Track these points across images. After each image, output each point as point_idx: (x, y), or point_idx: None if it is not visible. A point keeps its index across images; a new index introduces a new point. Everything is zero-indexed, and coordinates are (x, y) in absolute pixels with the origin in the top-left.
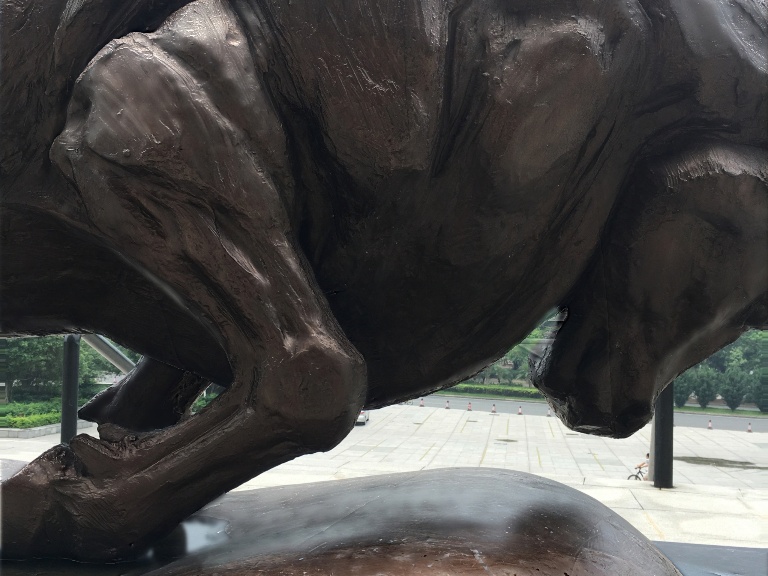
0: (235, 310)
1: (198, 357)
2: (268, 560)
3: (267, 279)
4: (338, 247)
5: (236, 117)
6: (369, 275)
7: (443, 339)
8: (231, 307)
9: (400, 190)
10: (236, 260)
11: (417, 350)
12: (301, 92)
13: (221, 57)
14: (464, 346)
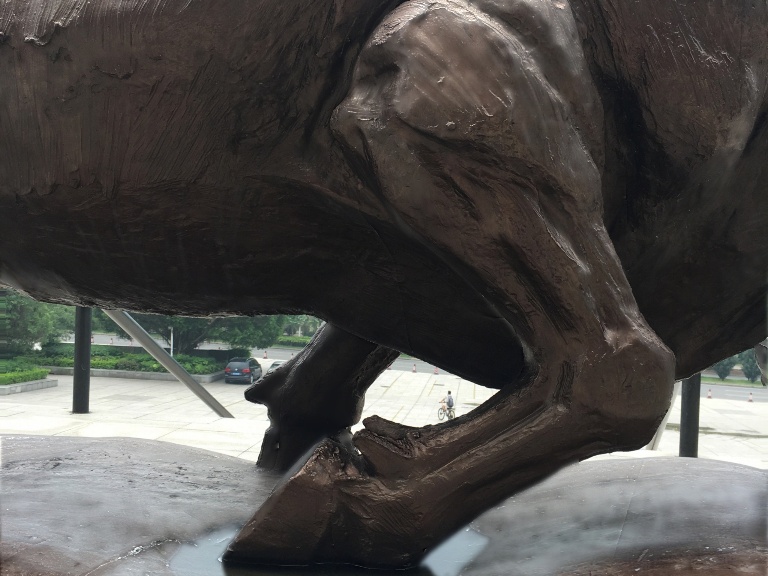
0: (550, 299)
1: (434, 343)
2: (600, 570)
3: (587, 266)
4: (628, 231)
5: (564, 88)
6: (652, 261)
7: (703, 328)
8: (545, 296)
9: (713, 171)
10: (559, 246)
11: (675, 339)
12: (621, 62)
13: (550, 21)
14: (723, 336)
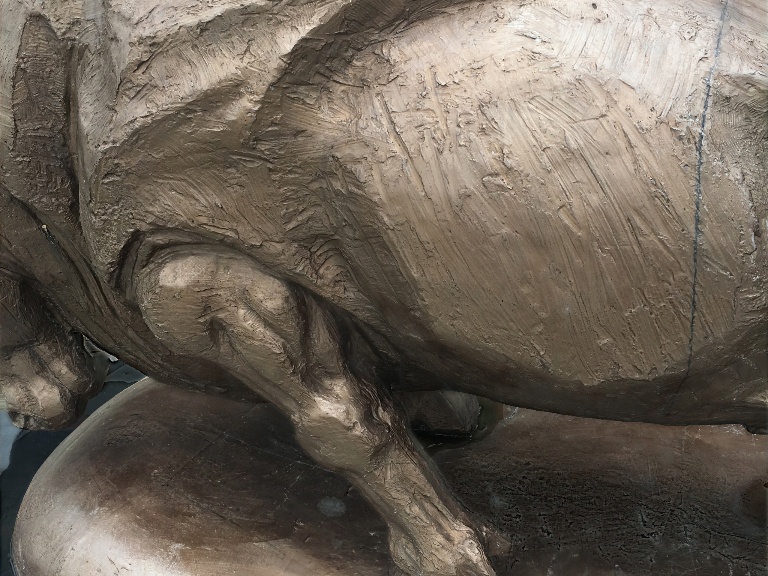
0: None
1: None
2: None
3: None
4: None
5: None
6: None
7: None
8: None
9: None
10: None
11: None
12: None
13: None
14: None
